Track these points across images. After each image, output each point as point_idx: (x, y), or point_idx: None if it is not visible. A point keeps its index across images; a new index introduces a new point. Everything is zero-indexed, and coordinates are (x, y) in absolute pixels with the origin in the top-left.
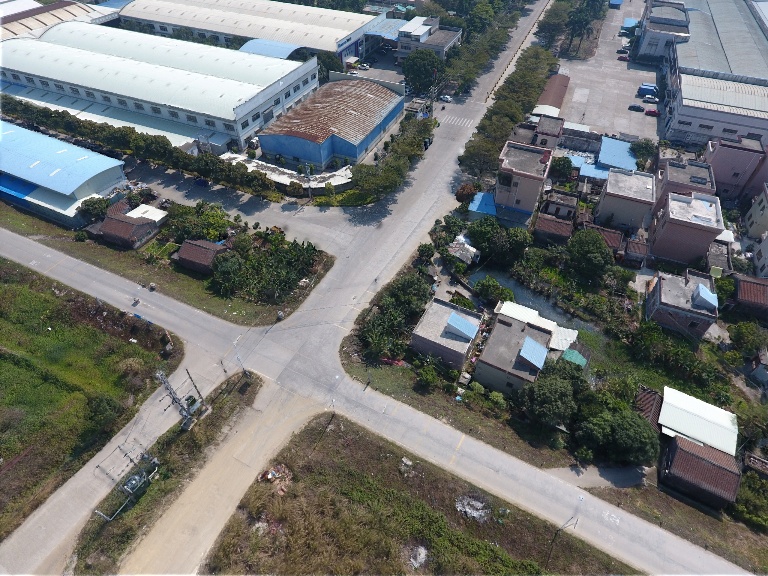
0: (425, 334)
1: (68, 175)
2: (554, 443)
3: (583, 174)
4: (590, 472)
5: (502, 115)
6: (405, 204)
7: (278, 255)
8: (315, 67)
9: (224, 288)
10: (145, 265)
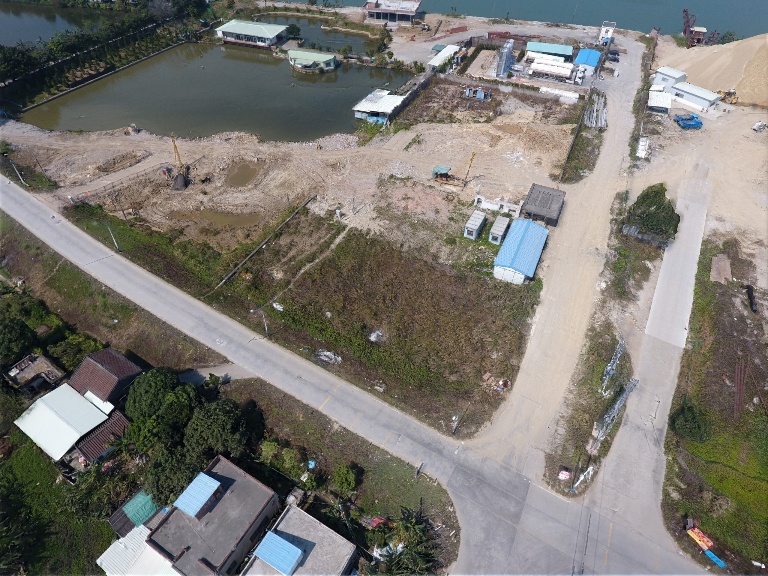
0: (337, 549)
1: None
2: None
3: None
4: None
5: None
6: None
7: None
8: None
9: None
10: None
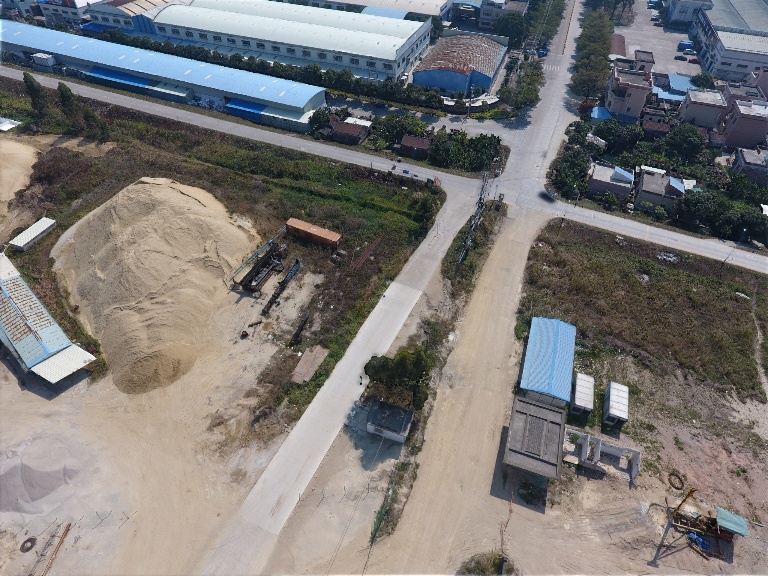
0: None
1: (294, 95)
2: (702, 232)
3: (661, 97)
4: (730, 242)
5: (598, 55)
6: (538, 118)
7: (471, 144)
8: (430, 26)
9: (446, 161)
10: (376, 152)
